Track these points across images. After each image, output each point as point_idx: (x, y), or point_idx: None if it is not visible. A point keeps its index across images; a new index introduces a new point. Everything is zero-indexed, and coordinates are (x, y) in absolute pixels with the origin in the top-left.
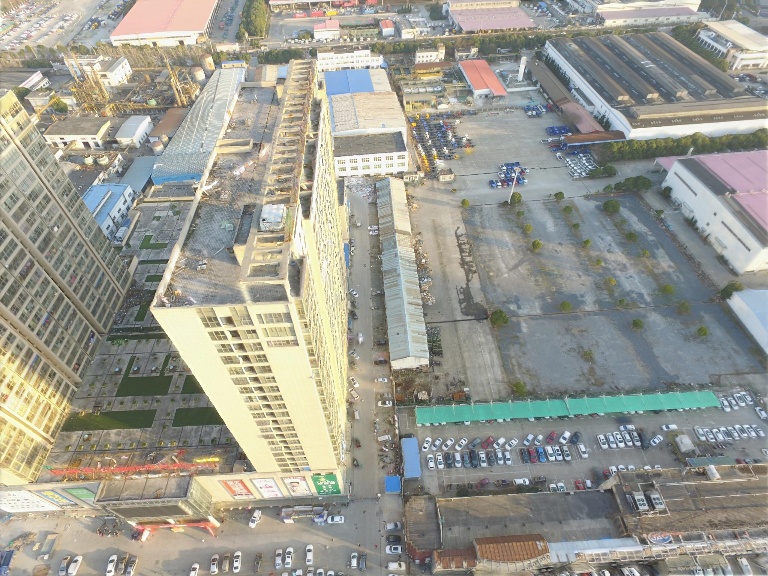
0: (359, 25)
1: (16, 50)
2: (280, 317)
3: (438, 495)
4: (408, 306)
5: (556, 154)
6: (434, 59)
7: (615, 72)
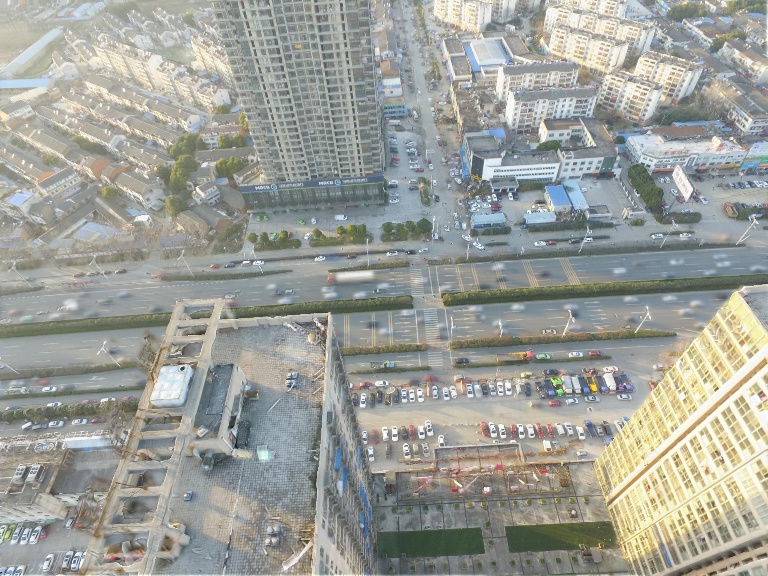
0: None
1: None
2: None
3: None
4: None
5: None
6: None
7: None
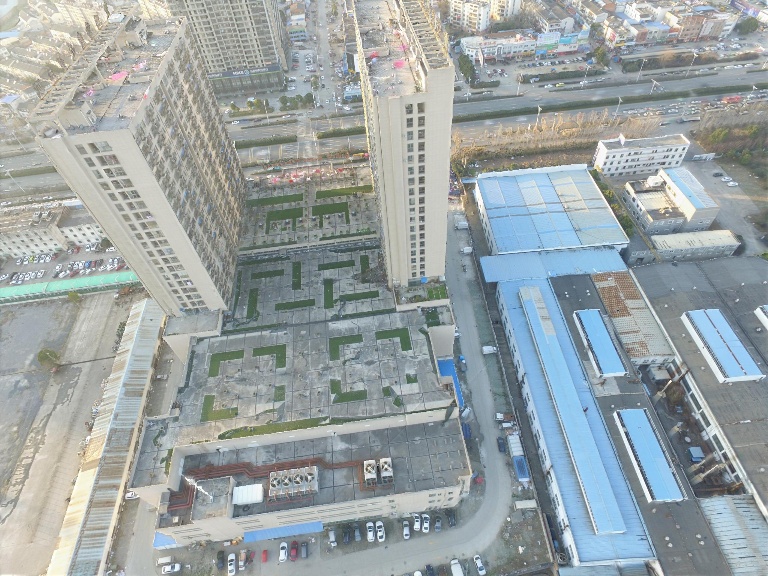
0: None
1: None
2: None
3: None
4: (130, 347)
5: None
6: None
7: None
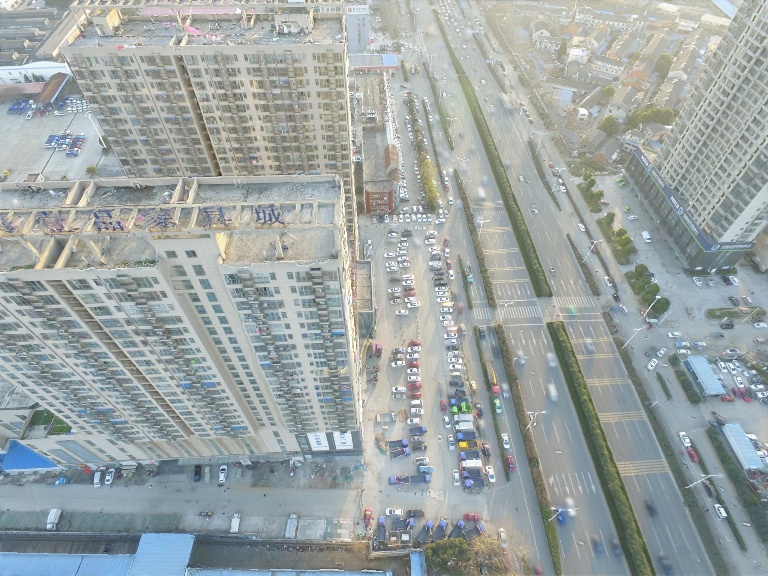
0: None
1: None
2: None
3: None
4: None
5: (55, 114)
6: None
7: None
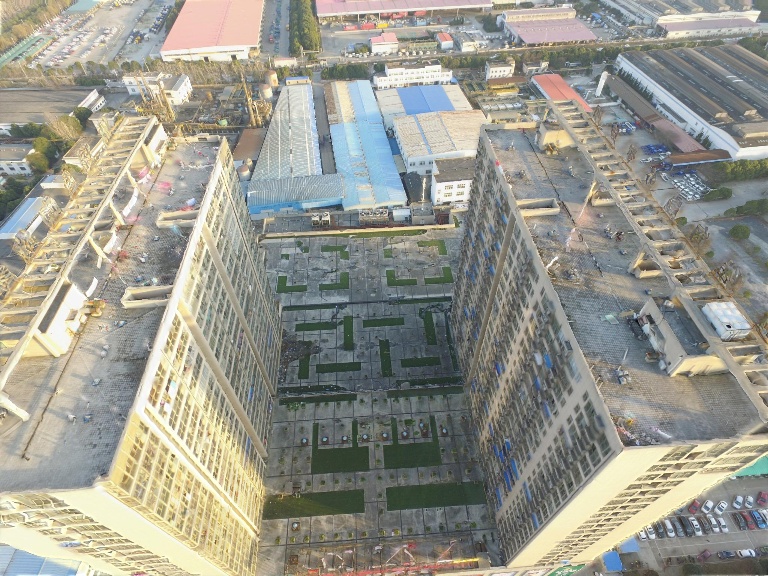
0: (415, 38)
1: (60, 66)
2: (755, 448)
3: (659, 571)
4: None
5: (661, 175)
6: (507, 74)
7: (702, 87)
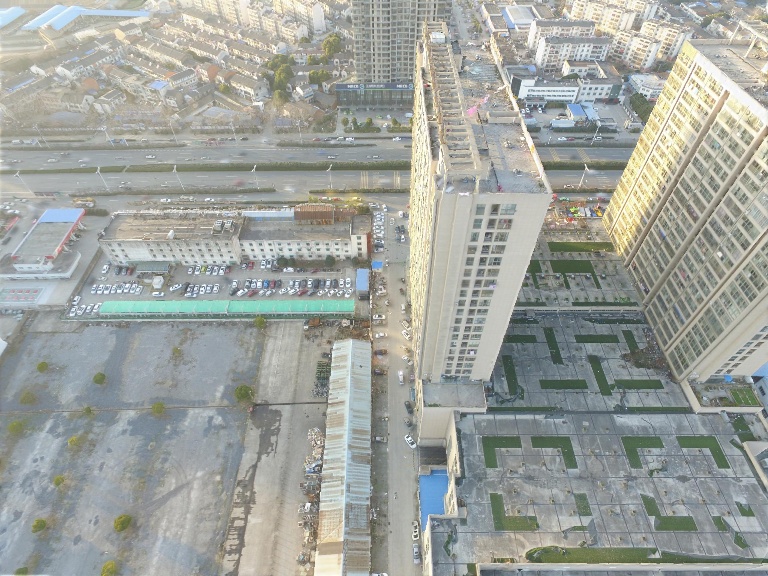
0: None
1: None
2: None
3: (347, 267)
4: (345, 398)
5: None
6: None
7: None
